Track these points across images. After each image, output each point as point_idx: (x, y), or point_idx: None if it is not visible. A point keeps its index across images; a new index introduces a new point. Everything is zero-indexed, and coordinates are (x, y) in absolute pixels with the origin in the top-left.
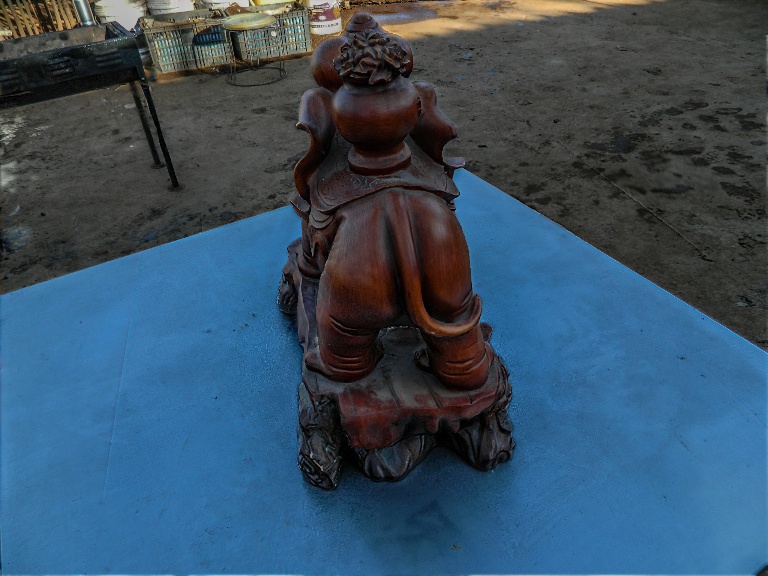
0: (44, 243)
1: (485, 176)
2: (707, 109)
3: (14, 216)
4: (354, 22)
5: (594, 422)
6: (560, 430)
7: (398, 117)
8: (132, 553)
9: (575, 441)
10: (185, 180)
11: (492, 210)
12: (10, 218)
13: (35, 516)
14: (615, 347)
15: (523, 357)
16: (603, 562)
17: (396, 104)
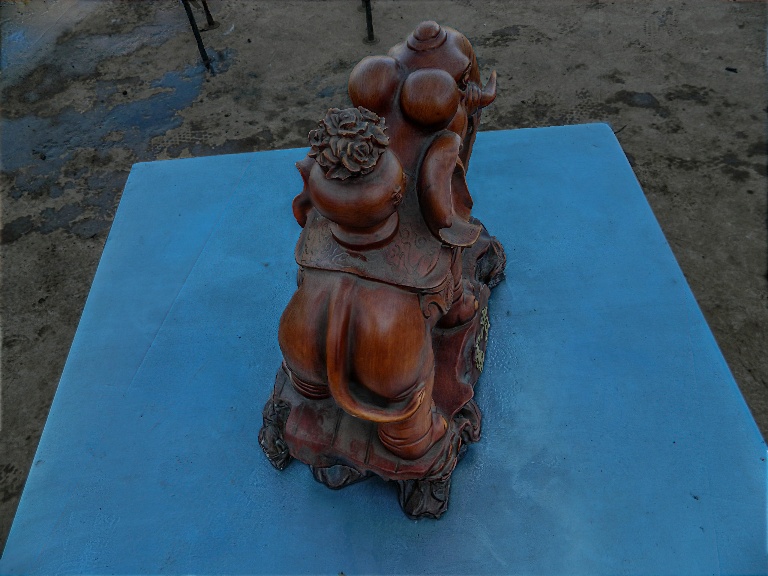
0: (241, 73)
1: (710, 114)
2: None
3: (227, 36)
4: (415, 36)
5: (544, 522)
6: (504, 513)
7: (358, 213)
8: (124, 449)
9: (511, 532)
10: (383, 33)
11: (612, 216)
12: (223, 37)
13: (81, 385)
14: (628, 449)
15: (522, 417)
16: None
17: (357, 201)
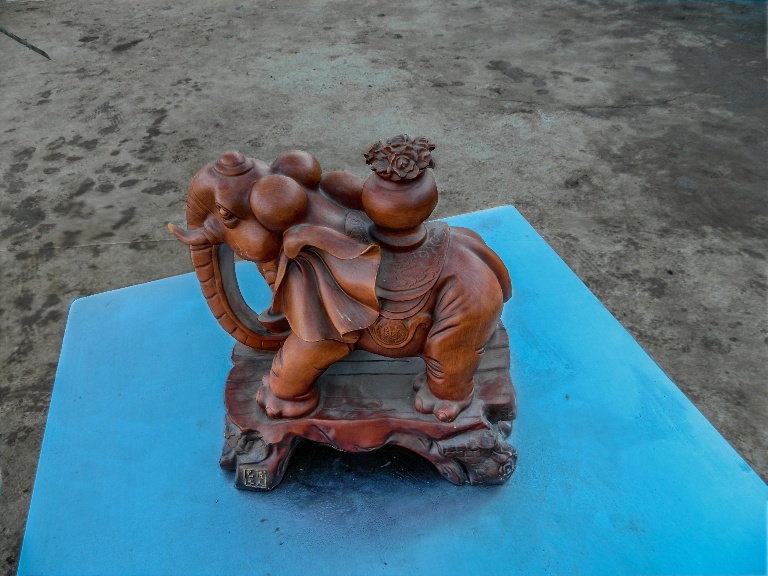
0: None
1: None
2: (40, 151)
3: None
4: (238, 164)
5: None
6: None
7: None
8: None
9: None
10: None
11: None
12: None
13: None
14: None
15: None
16: (577, 333)
17: None
